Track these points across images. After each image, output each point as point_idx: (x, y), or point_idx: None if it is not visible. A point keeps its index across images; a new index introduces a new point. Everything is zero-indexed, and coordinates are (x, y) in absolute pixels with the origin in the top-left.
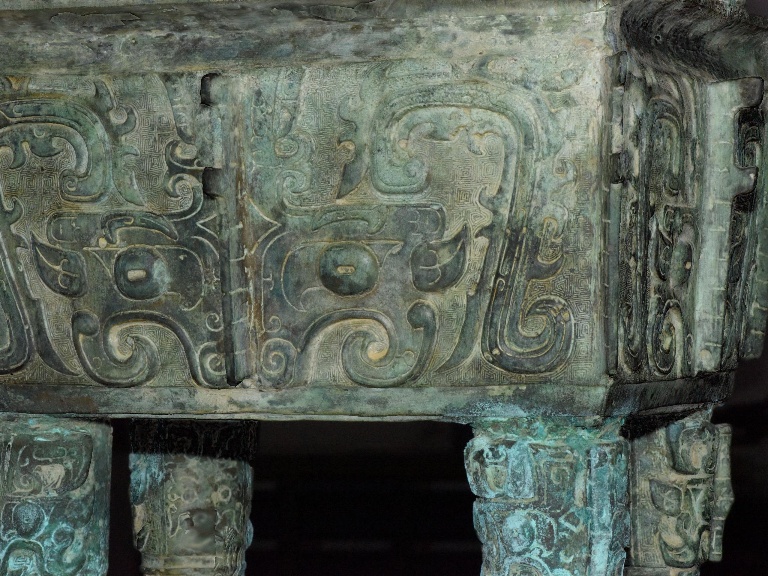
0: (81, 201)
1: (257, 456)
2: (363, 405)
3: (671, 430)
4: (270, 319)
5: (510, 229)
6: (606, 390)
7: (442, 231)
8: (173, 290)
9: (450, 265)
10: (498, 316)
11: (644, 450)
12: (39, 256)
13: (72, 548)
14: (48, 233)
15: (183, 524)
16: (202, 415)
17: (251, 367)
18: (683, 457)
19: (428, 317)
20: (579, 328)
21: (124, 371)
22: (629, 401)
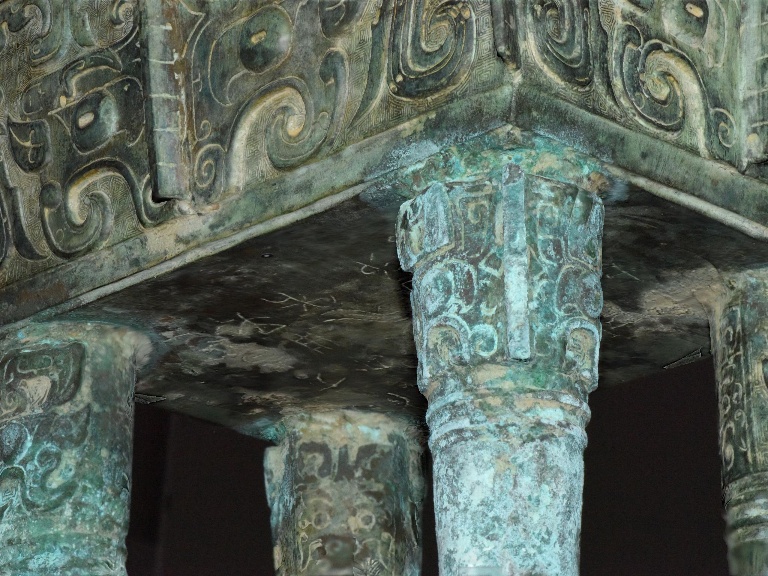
0: (44, 62)
1: (425, 493)
2: (291, 197)
3: None
4: (201, 125)
5: None
6: (513, 89)
7: None
8: (120, 128)
9: None
10: (399, 36)
11: (755, 327)
12: (12, 137)
13: (61, 474)
14: (20, 109)
15: (314, 554)
16: (158, 270)
17: (184, 185)
18: None
19: (335, 63)
20: (480, 23)
21: (81, 235)
22: (579, 132)
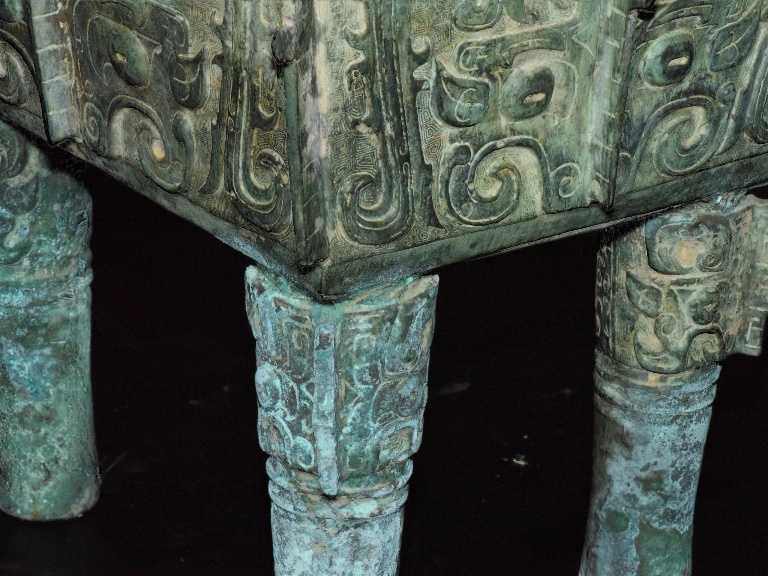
0: None
1: None
2: (161, 198)
3: (646, 224)
4: (86, 82)
5: (233, 67)
6: (323, 270)
7: (186, 46)
8: (24, 20)
9: (194, 86)
10: (231, 157)
11: (625, 236)
12: None
13: (17, 232)
14: None
15: None
16: None
17: (76, 126)
18: (661, 256)
19: (183, 134)
20: None
21: (3, 87)
22: (399, 266)
